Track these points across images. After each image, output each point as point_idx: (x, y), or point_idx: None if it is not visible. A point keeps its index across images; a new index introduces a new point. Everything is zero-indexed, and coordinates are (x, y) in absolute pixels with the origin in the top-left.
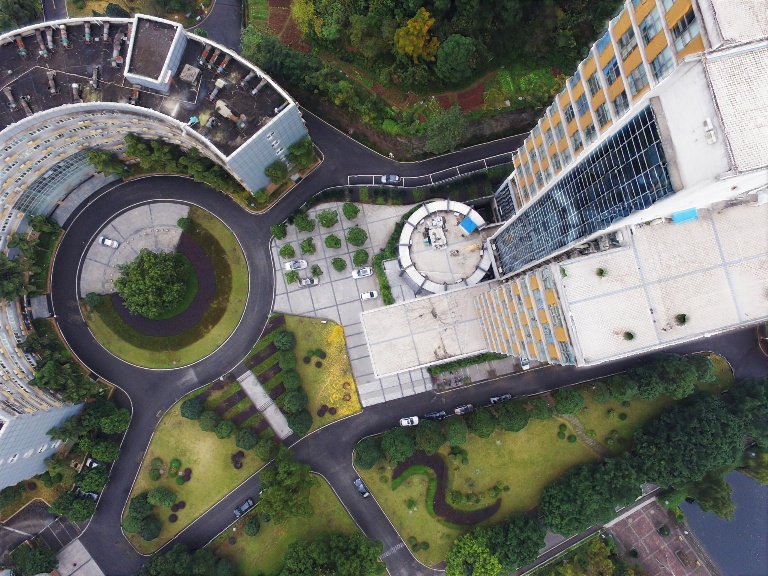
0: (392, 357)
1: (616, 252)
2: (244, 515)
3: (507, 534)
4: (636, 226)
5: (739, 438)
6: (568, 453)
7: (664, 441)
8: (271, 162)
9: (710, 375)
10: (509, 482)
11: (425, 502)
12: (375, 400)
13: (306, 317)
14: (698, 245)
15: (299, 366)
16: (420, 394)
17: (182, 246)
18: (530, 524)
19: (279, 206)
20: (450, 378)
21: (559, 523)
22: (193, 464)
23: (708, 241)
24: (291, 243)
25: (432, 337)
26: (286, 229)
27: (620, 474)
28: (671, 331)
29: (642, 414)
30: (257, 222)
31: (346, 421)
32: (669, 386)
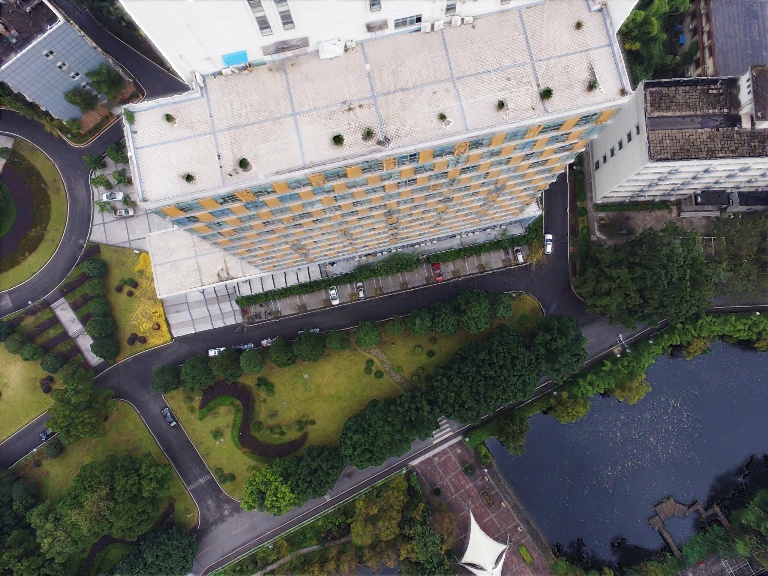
0: (175, 277)
1: (189, 100)
2: (50, 439)
3: (300, 463)
4: (211, 76)
5: (529, 371)
6: (375, 389)
7: (455, 373)
8: (69, 88)
9: (506, 309)
10: (316, 416)
11: (231, 433)
12: (185, 330)
13: (120, 247)
14: (270, 95)
15: (111, 294)
16: (230, 326)
17: (4, 175)
18: (324, 454)
19: (101, 140)
20: (260, 311)
21: (352, 454)
22: (3, 387)
23: (280, 92)
24: (110, 175)
25: (216, 259)
26: (105, 161)
27: (413, 406)
28: (236, 176)
29: (450, 352)
30: (78, 154)
31: (156, 350)
32: (460, 318)
